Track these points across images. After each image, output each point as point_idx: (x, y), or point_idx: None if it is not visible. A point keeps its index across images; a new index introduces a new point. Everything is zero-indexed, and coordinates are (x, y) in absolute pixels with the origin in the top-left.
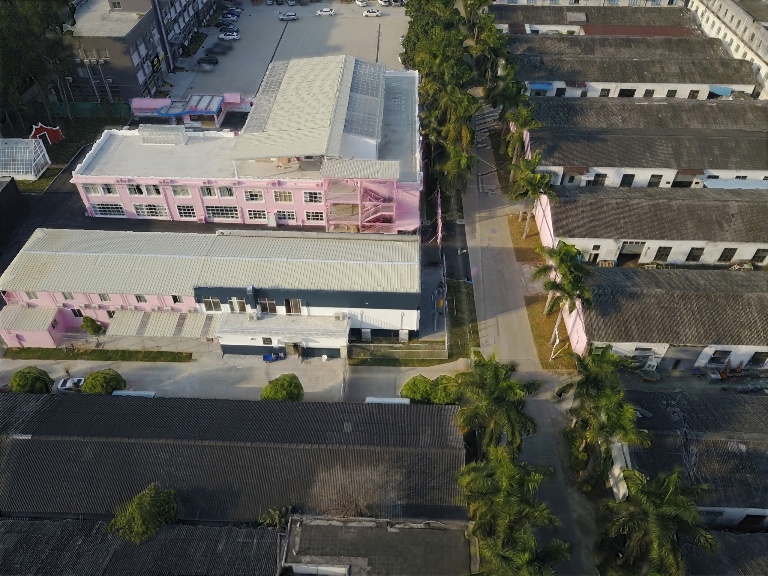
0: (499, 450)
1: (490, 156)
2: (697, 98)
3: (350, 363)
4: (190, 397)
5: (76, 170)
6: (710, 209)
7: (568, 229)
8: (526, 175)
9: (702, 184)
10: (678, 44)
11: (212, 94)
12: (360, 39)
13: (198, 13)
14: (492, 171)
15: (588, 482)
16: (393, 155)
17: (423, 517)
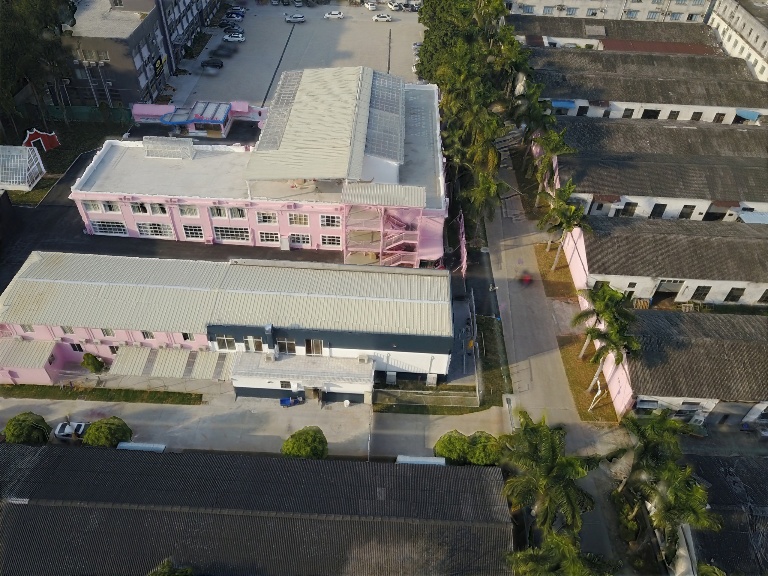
0: (553, 529)
1: (512, 178)
2: (723, 121)
3: (374, 409)
4: (201, 446)
5: (75, 185)
6: (752, 247)
7: (604, 265)
8: (560, 206)
9: (736, 216)
10: (702, 63)
11: (217, 100)
12: (370, 45)
13: (201, 12)
14: (515, 194)
15: (640, 556)
16: (415, 177)
17: None
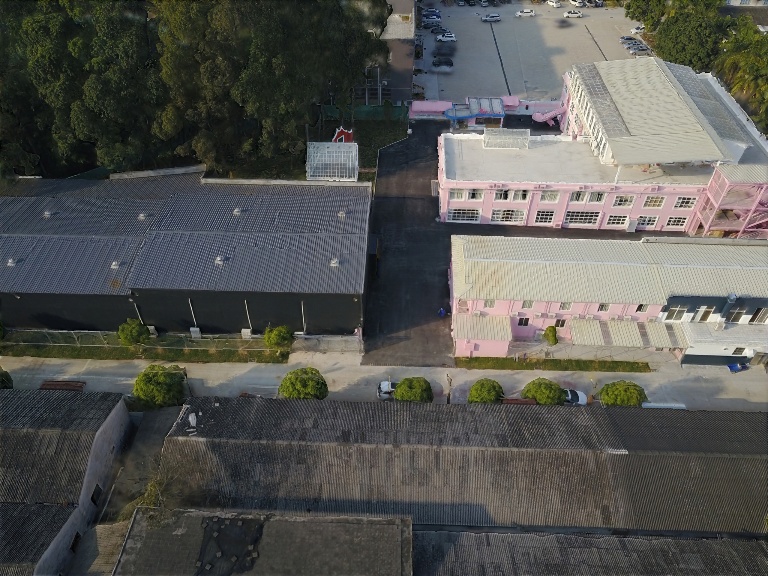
0: None
1: None
2: None
3: None
4: None
5: (444, 175)
6: None
7: None
8: None
9: None
10: None
11: (467, 96)
12: (576, 40)
13: None
14: None
15: None
16: (750, 159)
17: None
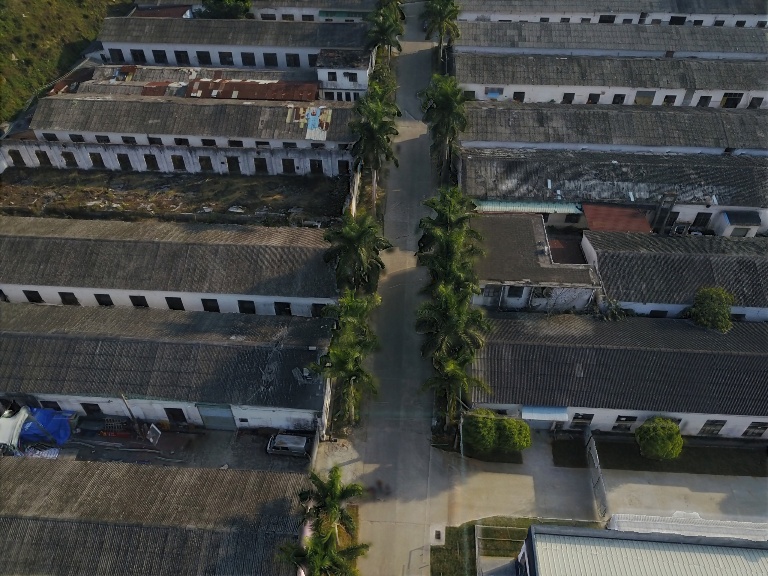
0: None
1: None
2: None
3: None
4: (767, 480)
5: None
6: None
7: None
8: None
9: None
10: None
11: None
12: None
13: None
14: None
15: None
16: None
17: (501, 315)
